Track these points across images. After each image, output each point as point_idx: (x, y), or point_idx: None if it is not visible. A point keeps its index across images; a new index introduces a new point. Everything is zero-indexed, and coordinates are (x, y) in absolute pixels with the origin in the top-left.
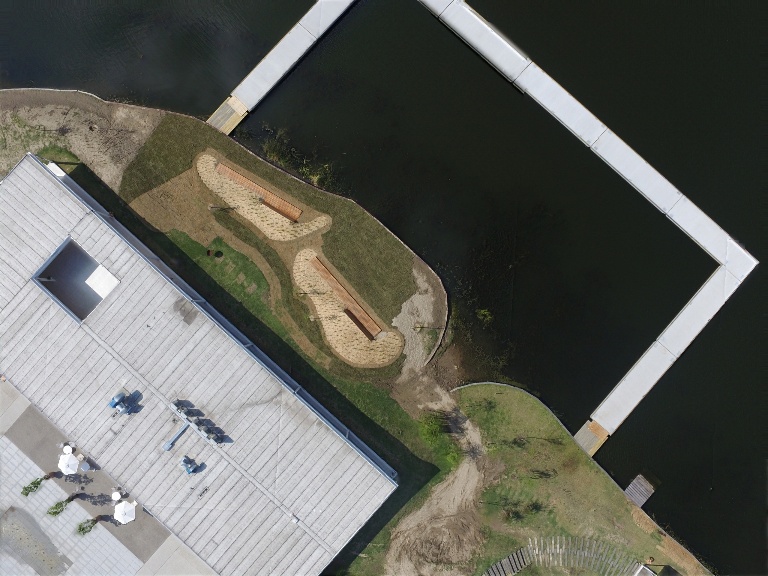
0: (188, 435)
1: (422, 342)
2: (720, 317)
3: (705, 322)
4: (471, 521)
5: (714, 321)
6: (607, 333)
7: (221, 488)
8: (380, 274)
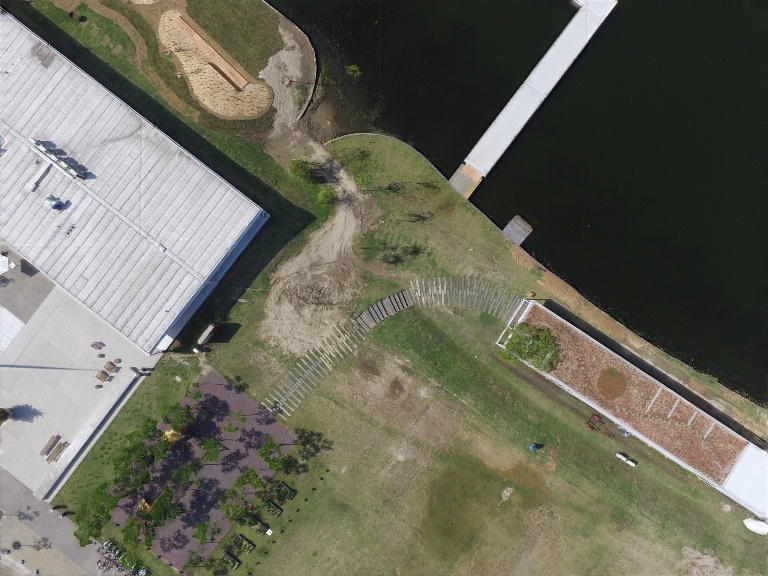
0: (52, 175)
1: (292, 96)
2: (586, 59)
3: (570, 62)
4: (351, 267)
5: (581, 64)
6: (476, 80)
7: (87, 224)
8: (246, 32)
